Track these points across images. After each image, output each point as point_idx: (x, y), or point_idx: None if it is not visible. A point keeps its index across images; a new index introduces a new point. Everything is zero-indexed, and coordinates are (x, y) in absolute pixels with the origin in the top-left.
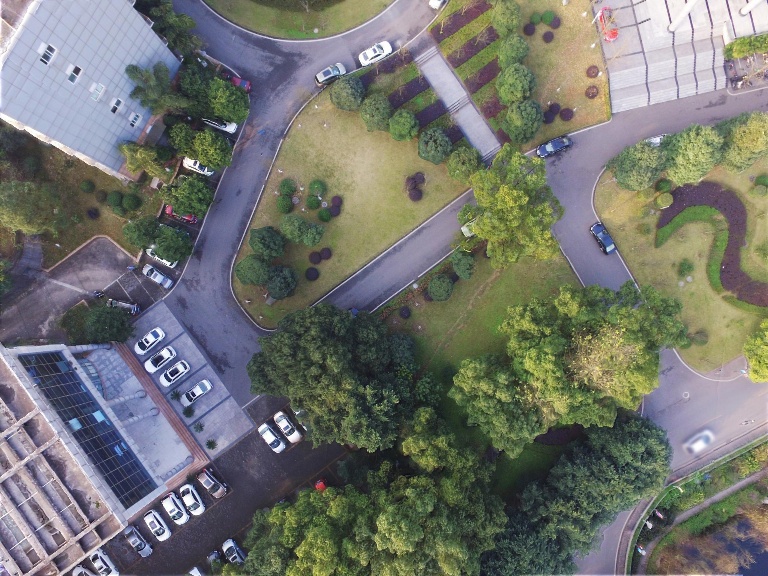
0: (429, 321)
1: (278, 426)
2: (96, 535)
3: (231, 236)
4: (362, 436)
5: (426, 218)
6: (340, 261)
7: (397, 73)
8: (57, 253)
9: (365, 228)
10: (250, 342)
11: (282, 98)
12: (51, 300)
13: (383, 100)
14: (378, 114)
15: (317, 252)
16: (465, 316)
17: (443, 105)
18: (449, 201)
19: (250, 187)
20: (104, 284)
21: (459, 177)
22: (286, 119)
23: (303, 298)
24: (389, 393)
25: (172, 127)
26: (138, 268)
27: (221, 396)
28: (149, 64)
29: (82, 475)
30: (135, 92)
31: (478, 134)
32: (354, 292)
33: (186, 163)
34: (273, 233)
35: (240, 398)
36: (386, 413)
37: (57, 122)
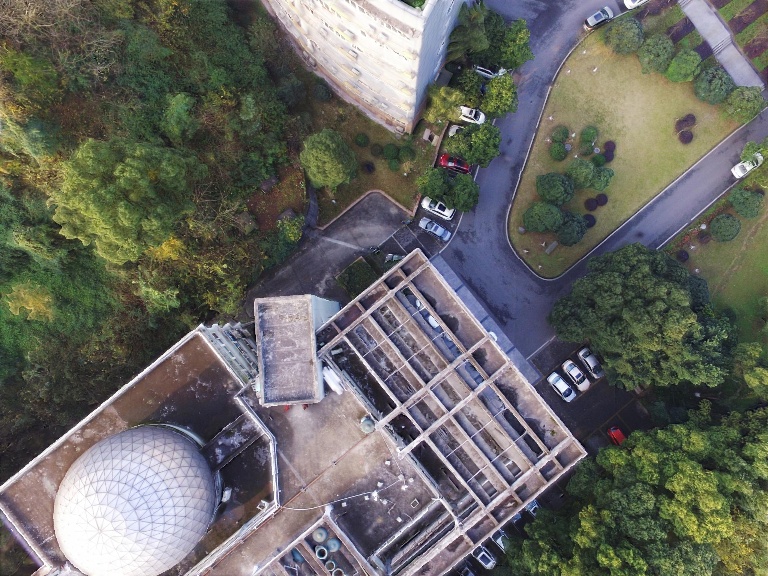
0: (705, 264)
1: (568, 375)
2: (556, 462)
3: (504, 186)
4: (702, 371)
5: (695, 161)
6: (614, 207)
7: (663, 15)
8: (332, 210)
9: (637, 173)
10: (530, 292)
11: (548, 45)
12: (326, 258)
13: (668, 39)
14: (665, 53)
15: (593, 198)
16: (740, 257)
17: (709, 46)
18: (716, 143)
19: (521, 136)
20: (379, 240)
21: (738, 116)
22: (553, 66)
23: (580, 246)
24: (715, 329)
25: (465, 73)
26: (413, 222)
27: (505, 348)
28: (470, 3)
29: (534, 403)
30: (454, 33)
31: (742, 75)
32: (629, 238)
33: (462, 113)
34: (566, 177)
35: (524, 349)
36: (714, 349)
37: (427, 56)
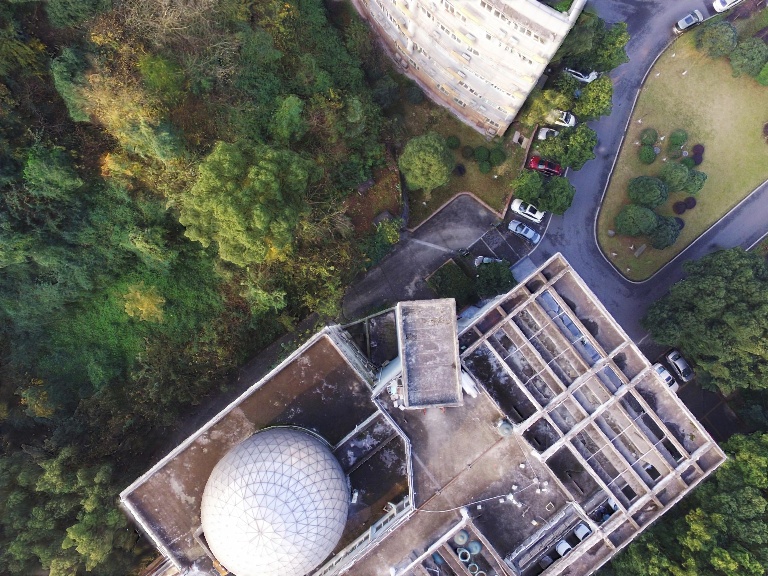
0: None
1: None
2: (697, 467)
3: (593, 189)
4: None
5: None
6: (702, 210)
7: (752, 19)
8: (422, 212)
9: (725, 176)
10: (618, 295)
11: (637, 48)
12: (416, 260)
13: (762, 43)
14: (759, 57)
15: (681, 202)
16: None
17: None
18: None
19: (609, 139)
20: (468, 242)
21: None
22: (642, 69)
23: (668, 249)
24: None
25: (563, 75)
26: (501, 225)
27: (593, 351)
28: None
29: (673, 407)
30: None
31: None
32: (716, 241)
33: None
34: None
35: None
36: None
37: None
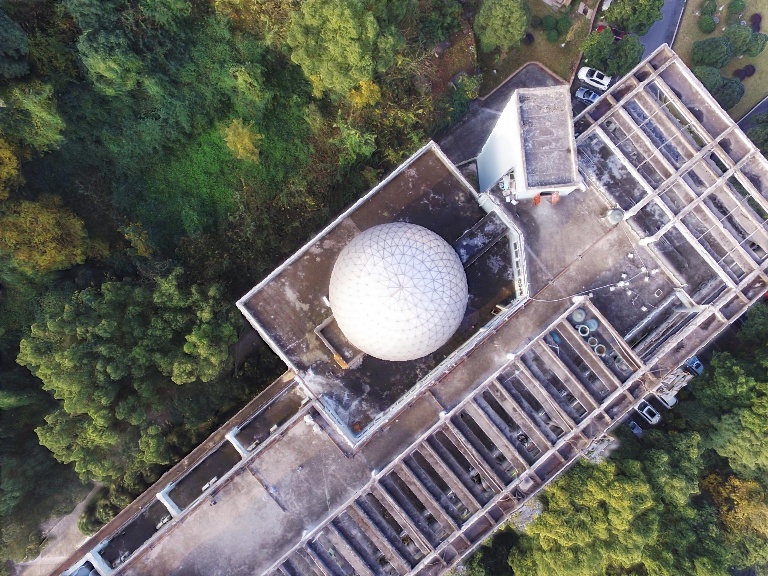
0: None
1: None
2: None
3: None
4: None
5: None
6: (761, 78)
7: None
8: (493, 80)
9: None
10: None
11: None
12: (487, 128)
13: None
14: None
15: (741, 69)
16: None
17: None
18: None
19: (670, 10)
20: None
21: None
22: None
23: None
24: None
25: None
26: None
27: None
28: None
29: None
30: None
31: None
32: None
33: None
34: None
35: None
36: None
37: None
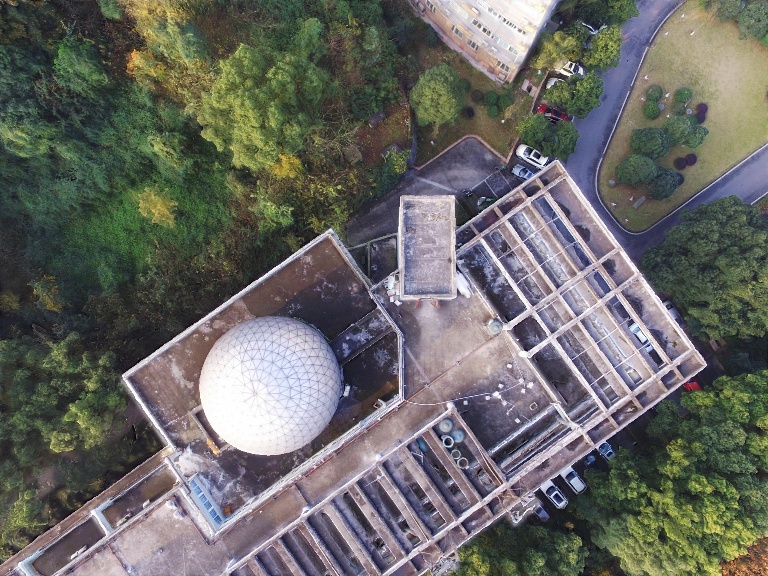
0: None
1: None
2: (677, 372)
3: (597, 140)
4: None
5: None
6: (702, 168)
7: None
8: (430, 151)
9: (727, 136)
10: None
11: (648, 7)
12: None
13: None
14: (765, 19)
15: (682, 158)
16: None
17: None
18: None
19: (616, 93)
20: (472, 184)
21: None
22: (651, 27)
23: (667, 203)
24: None
25: (573, 23)
26: (505, 169)
27: None
28: None
29: (658, 315)
30: None
31: None
32: (714, 199)
33: None
34: None
35: None
36: None
37: None
